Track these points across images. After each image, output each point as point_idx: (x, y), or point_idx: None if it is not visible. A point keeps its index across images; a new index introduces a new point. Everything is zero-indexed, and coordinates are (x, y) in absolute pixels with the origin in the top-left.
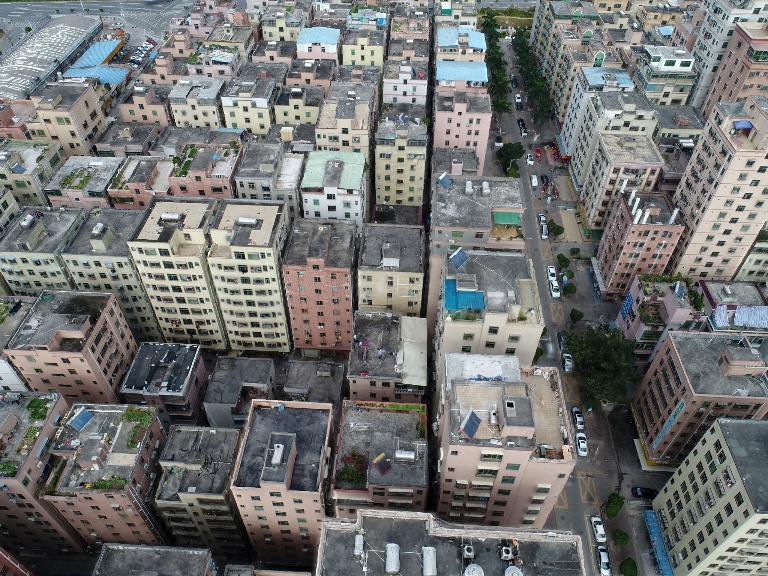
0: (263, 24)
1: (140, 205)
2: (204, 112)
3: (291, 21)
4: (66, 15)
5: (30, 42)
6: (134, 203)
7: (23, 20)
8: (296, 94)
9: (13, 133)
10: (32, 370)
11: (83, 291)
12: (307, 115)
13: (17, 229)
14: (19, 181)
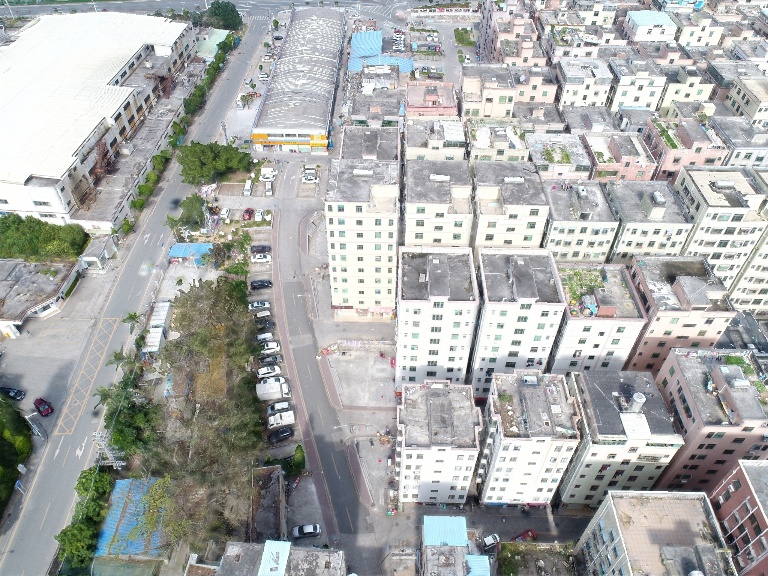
0: (580, 9)
1: (620, 178)
2: (596, 92)
3: (609, 5)
4: (311, 7)
5: (297, 33)
6: (615, 177)
7: (255, 14)
8: (690, 72)
9: (446, 113)
10: (661, 333)
11: (674, 256)
12: (698, 93)
13: (554, 201)
14: (515, 156)
